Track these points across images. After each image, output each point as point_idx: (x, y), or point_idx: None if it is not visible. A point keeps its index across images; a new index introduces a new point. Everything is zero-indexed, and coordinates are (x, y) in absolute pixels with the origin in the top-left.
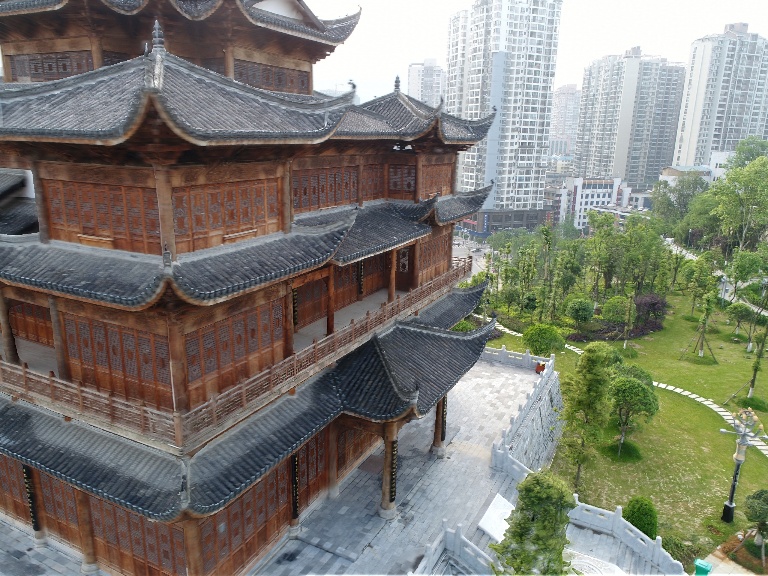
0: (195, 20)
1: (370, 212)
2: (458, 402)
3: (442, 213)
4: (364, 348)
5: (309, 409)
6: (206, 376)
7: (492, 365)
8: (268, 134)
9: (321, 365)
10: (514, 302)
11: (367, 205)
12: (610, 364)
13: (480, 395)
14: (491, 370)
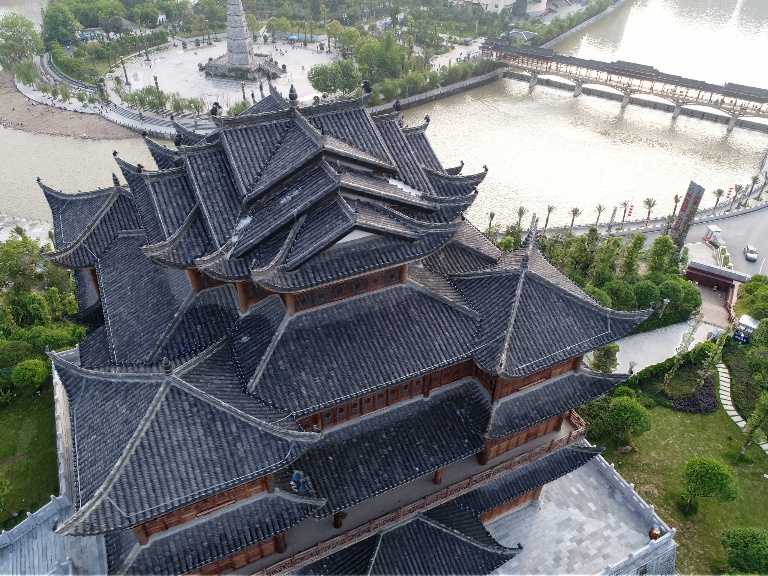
0: (250, 279)
1: (430, 408)
2: (527, 536)
3: (523, 415)
4: (368, 538)
5: None
6: None
7: (611, 495)
8: (203, 497)
9: (300, 566)
10: (759, 372)
11: (438, 392)
12: (753, 567)
13: (557, 537)
14: (602, 503)
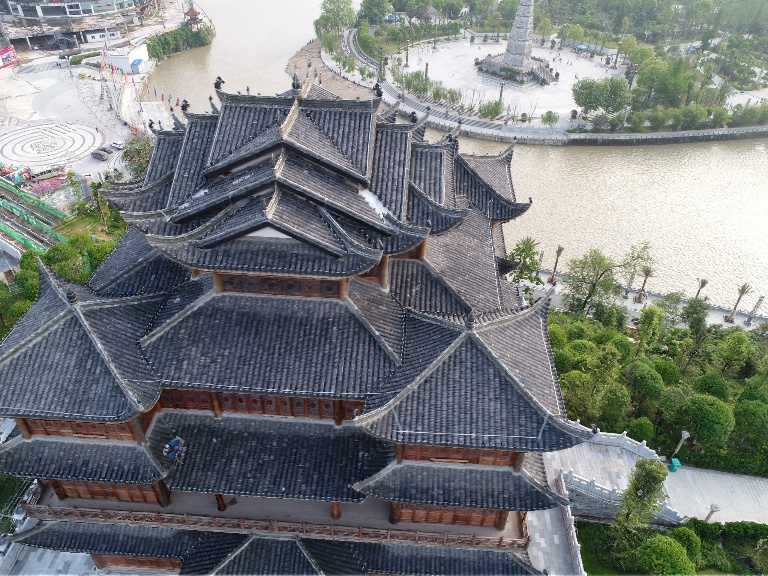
0: None
1: (335, 437)
2: None
3: (424, 488)
4: (242, 534)
5: (163, 539)
6: (77, 486)
7: None
8: (42, 416)
9: (167, 526)
10: None
11: (352, 425)
12: None
13: None
14: None
